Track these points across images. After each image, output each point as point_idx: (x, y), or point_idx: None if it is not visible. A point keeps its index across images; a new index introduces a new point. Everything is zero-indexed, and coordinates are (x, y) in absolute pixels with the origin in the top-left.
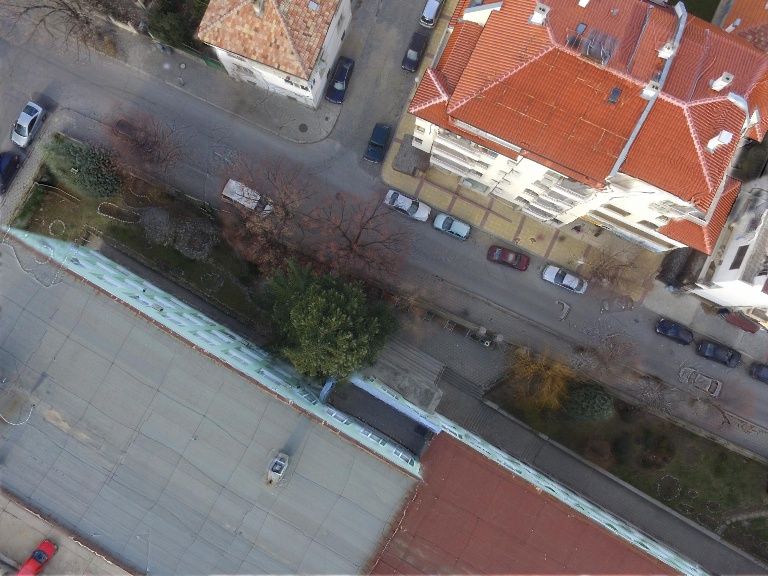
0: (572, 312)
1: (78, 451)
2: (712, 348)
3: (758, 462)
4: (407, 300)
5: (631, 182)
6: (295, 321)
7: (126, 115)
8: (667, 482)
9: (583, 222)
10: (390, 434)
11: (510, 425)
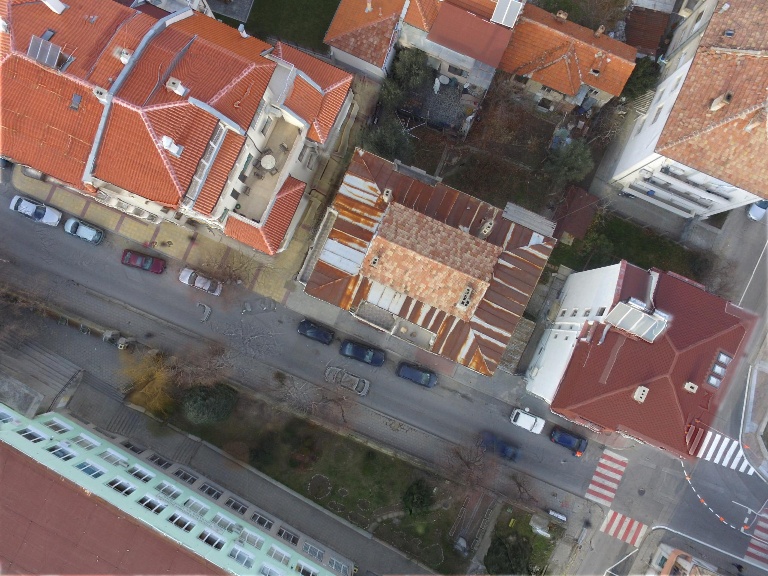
0: (214, 314)
1: None
2: (351, 347)
3: (401, 459)
4: (39, 305)
5: (112, 186)
6: None
7: None
8: (318, 481)
9: (205, 225)
10: None
11: (160, 427)
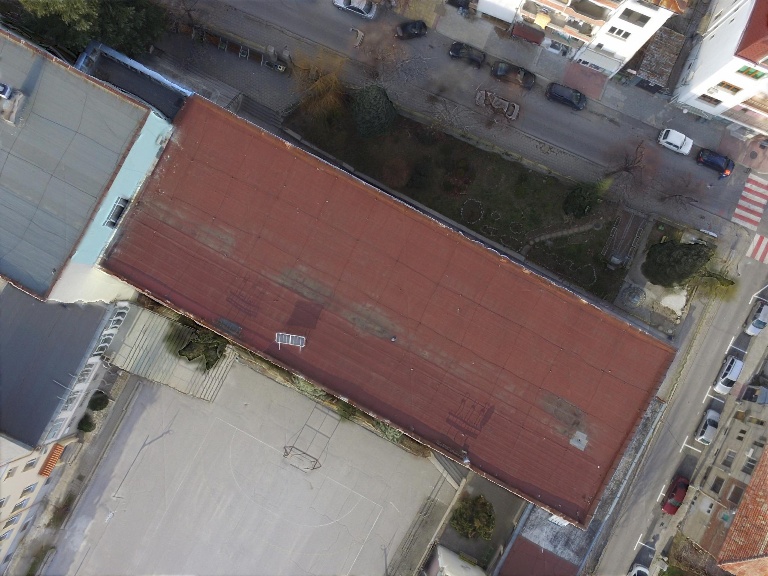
0: (366, 39)
1: None
2: (503, 66)
3: (554, 177)
4: (200, 28)
5: None
6: None
7: None
8: (470, 206)
9: None
10: None
11: None
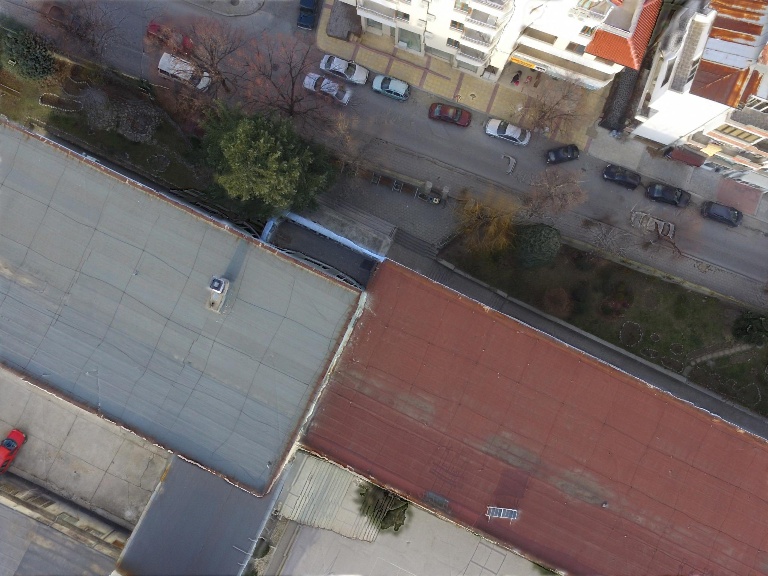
0: (519, 165)
1: (22, 296)
2: (660, 188)
3: (716, 298)
4: (353, 164)
5: None
6: (226, 150)
7: (58, 1)
8: (628, 328)
9: (519, 68)
10: (334, 266)
11: (468, 285)
